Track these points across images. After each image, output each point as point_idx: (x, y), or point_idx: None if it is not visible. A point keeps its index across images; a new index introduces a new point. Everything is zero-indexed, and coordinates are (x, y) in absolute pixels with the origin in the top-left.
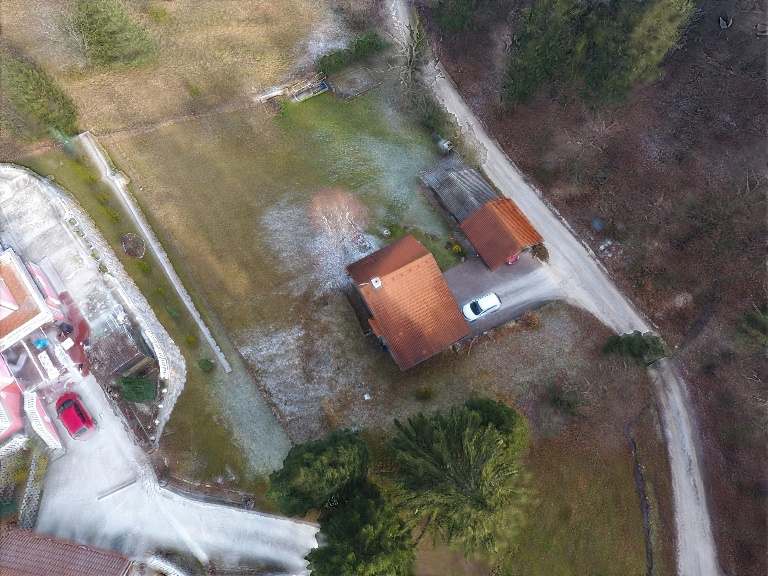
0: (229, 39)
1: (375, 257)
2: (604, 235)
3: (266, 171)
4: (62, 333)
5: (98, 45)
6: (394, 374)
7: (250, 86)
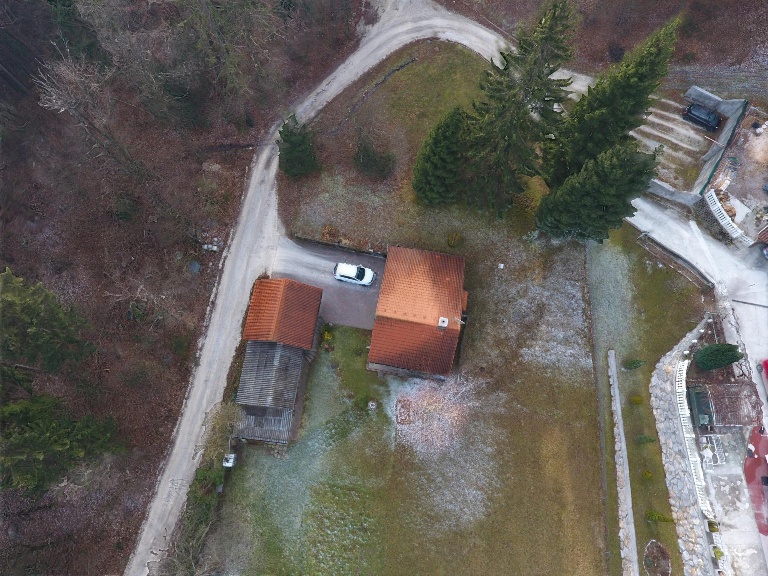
0: None
1: (418, 361)
2: (199, 259)
3: None
4: None
5: None
6: (466, 271)
7: None
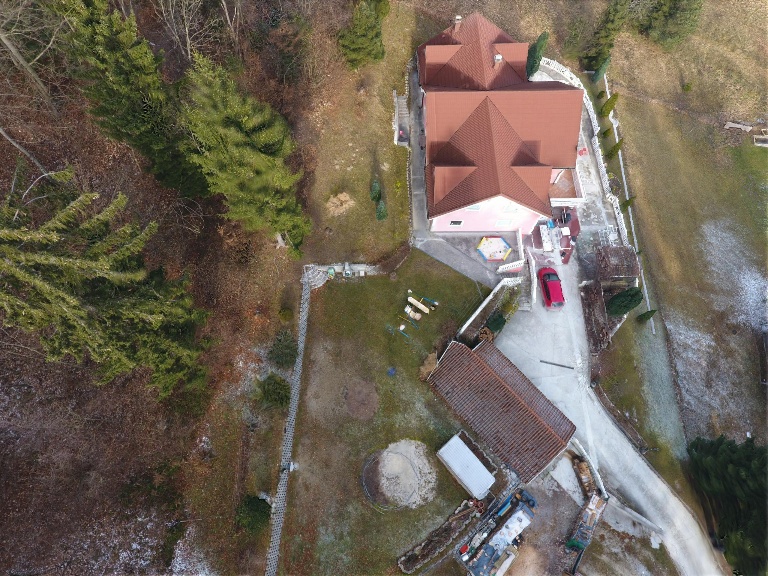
0: (722, 58)
1: None
2: None
3: (710, 187)
4: (557, 220)
5: (640, 8)
6: None
7: (721, 107)
